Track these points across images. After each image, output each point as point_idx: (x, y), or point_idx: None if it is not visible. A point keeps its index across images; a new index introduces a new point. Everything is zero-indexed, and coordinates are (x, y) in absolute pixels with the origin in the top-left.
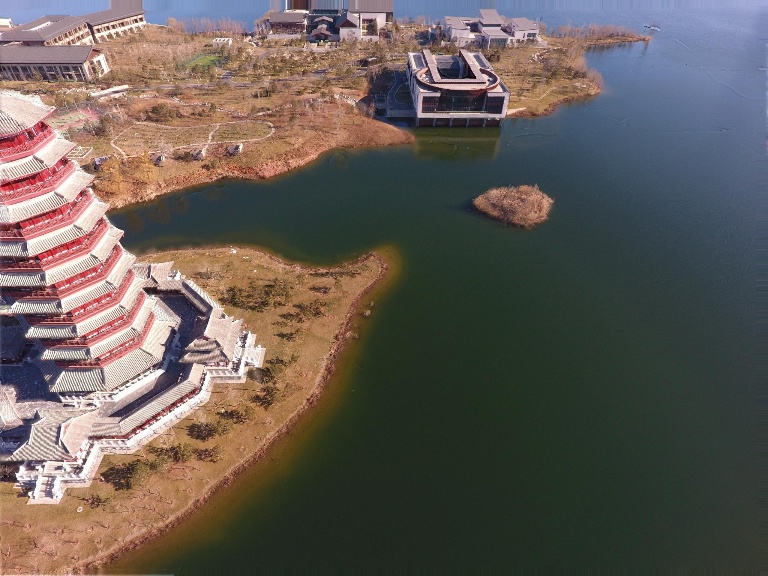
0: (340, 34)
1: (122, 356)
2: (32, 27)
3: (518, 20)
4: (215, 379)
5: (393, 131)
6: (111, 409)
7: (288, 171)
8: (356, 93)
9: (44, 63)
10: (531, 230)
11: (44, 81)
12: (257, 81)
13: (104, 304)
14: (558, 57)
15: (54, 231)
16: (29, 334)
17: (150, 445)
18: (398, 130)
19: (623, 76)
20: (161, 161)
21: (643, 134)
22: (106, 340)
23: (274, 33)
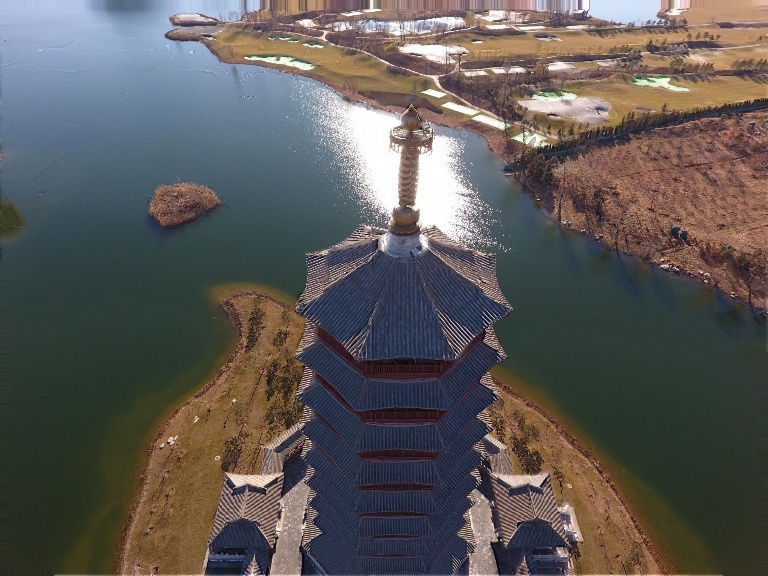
0: None
1: None
2: None
3: None
4: None
5: None
6: None
7: None
8: None
9: None
10: (227, 201)
11: None
12: None
13: None
14: None
15: None
16: (471, 499)
17: None
18: None
19: None
20: None
21: (100, 122)
22: None
23: None
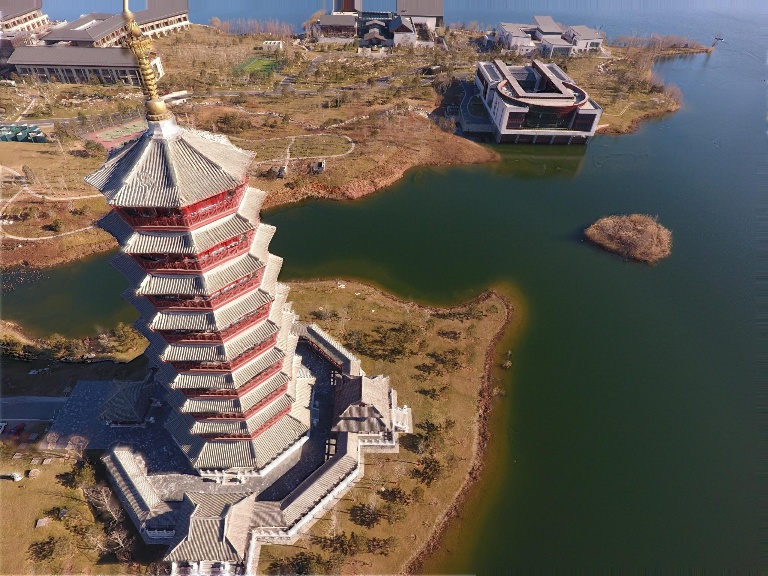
0: (394, 39)
1: (271, 425)
2: (78, 26)
3: (578, 28)
4: (365, 447)
5: (476, 148)
6: (259, 486)
7: (375, 191)
8: (427, 104)
9: (100, 66)
10: (657, 267)
11: (99, 85)
12: (323, 89)
13: (268, 372)
14: (627, 69)
15: (239, 297)
16: (185, 408)
17: (311, 533)
18: (480, 147)
19: (699, 91)
20: None
21: (740, 156)
22: (261, 410)
23: (325, 36)
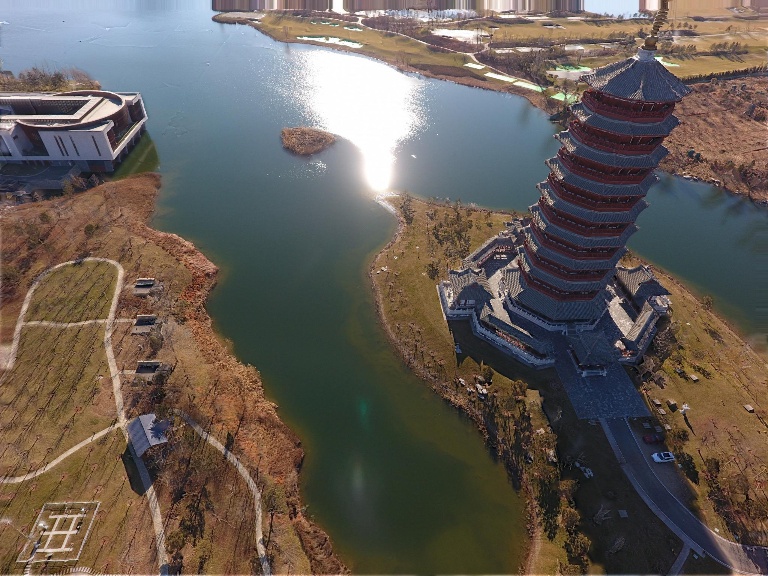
0: None
1: None
2: None
3: None
4: None
5: (127, 182)
6: None
7: None
8: None
9: None
10: (342, 138)
11: None
12: None
13: None
14: None
15: None
16: (626, 249)
17: None
18: (123, 180)
19: None
20: (162, 364)
21: (199, 85)
22: None
23: None
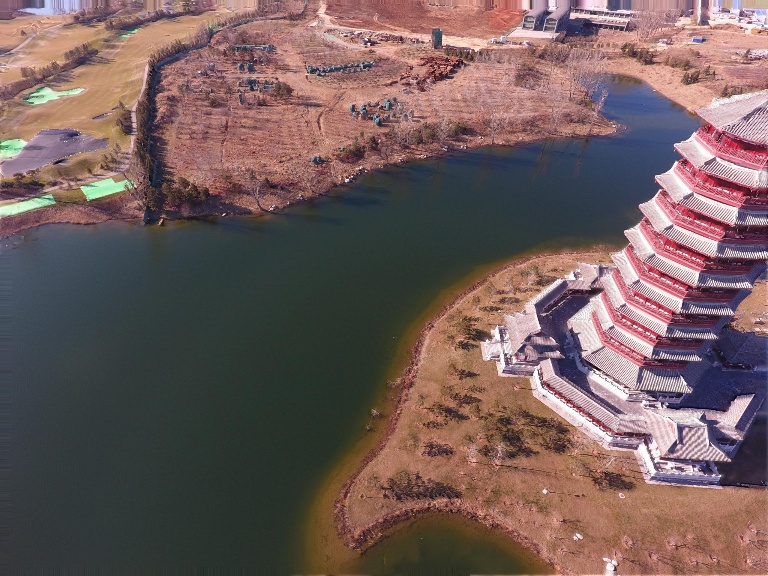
0: None
1: None
2: None
3: None
4: None
5: None
6: None
7: None
8: None
9: None
10: None
11: None
12: None
13: None
14: None
15: None
16: None
17: None
18: None
19: None
20: None
21: None
22: None
23: None
